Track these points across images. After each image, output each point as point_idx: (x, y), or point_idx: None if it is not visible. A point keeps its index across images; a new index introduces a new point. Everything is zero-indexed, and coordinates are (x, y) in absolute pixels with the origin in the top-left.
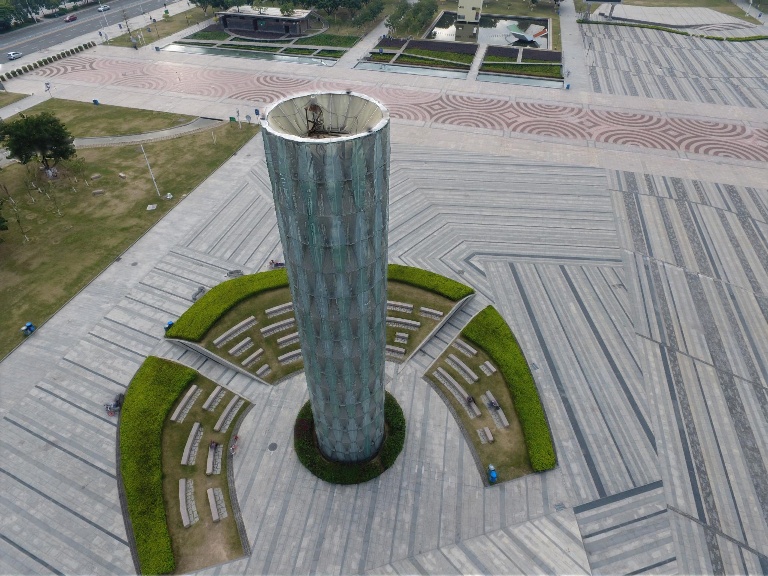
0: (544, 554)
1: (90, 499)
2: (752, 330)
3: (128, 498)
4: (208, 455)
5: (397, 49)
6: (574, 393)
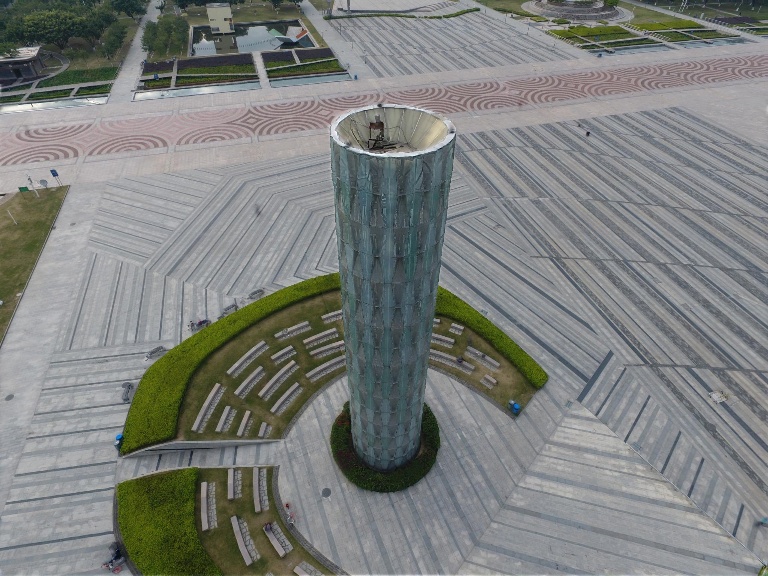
0: (583, 442)
1: None
2: (591, 225)
3: None
4: (269, 539)
5: (169, 72)
6: (523, 318)
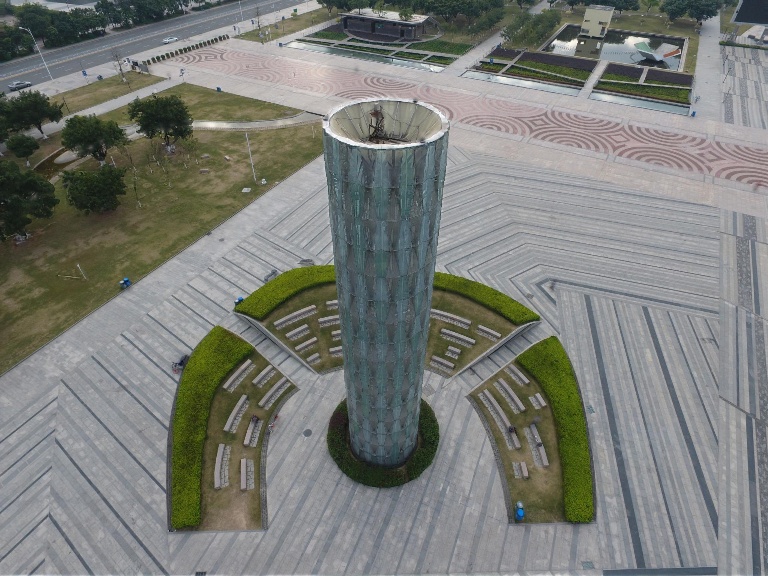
0: None
1: (143, 443)
2: None
3: (174, 450)
4: (248, 427)
5: (509, 60)
6: (630, 447)
